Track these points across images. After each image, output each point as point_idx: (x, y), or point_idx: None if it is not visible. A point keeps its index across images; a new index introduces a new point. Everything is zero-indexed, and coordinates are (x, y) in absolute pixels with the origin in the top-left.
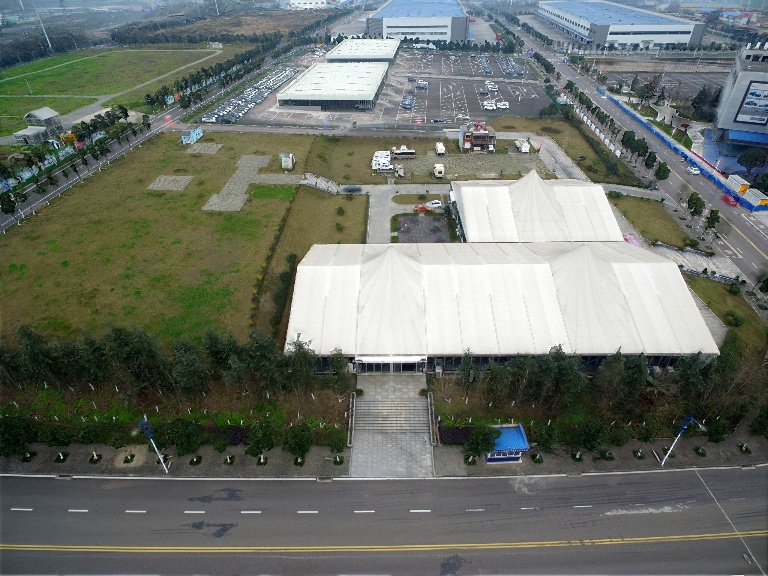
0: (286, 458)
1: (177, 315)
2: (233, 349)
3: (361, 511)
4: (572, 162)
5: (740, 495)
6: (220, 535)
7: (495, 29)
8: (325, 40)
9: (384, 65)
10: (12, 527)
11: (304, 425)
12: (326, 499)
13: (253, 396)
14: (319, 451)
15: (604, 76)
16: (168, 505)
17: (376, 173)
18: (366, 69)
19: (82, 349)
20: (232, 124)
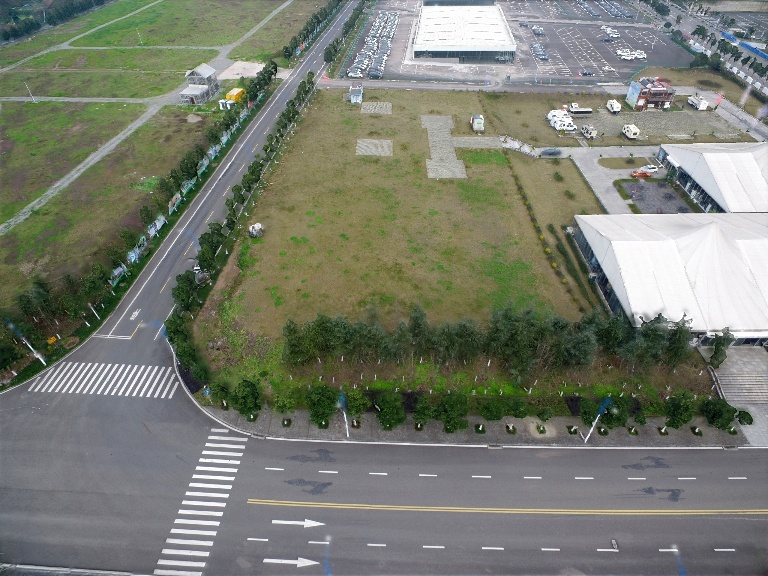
0: (682, 428)
1: (496, 290)
2: (619, 327)
3: None
4: (757, 121)
5: None
6: (675, 499)
7: None
8: None
9: (496, 9)
10: (486, 493)
11: None
12: (746, 466)
13: (617, 370)
14: None
15: (732, 20)
16: (608, 472)
17: (563, 134)
18: (482, 14)
19: (487, 329)
20: (382, 79)
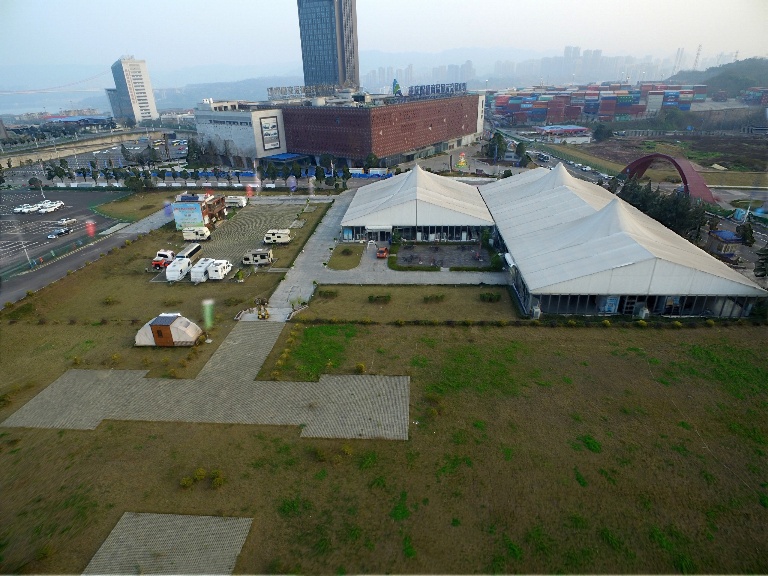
0: None
1: None
2: None
3: None
4: (286, 196)
5: None
6: None
7: None
8: None
9: None
10: None
11: None
12: None
13: None
14: None
15: (62, 160)
16: None
17: None
18: None
19: None
20: None
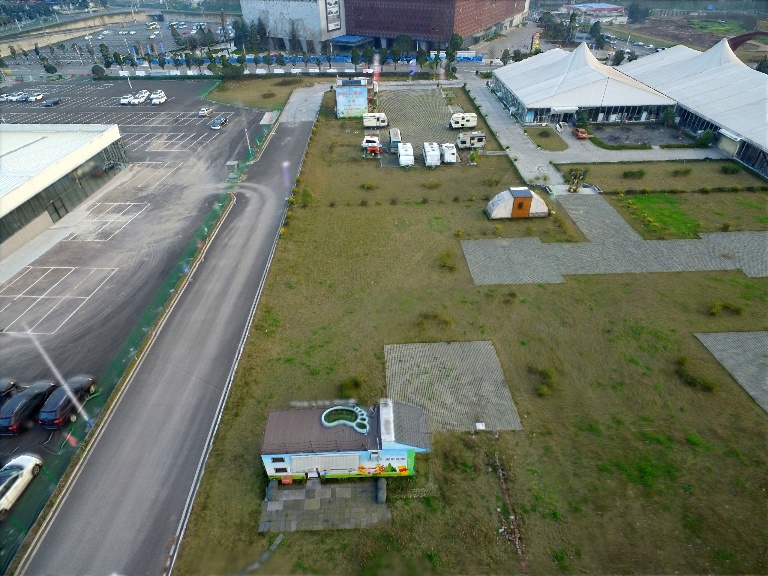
0: None
1: None
2: None
3: None
4: (404, 81)
5: None
6: None
7: None
8: None
9: None
10: None
11: None
12: None
13: None
14: None
15: (103, 45)
16: None
17: None
18: None
19: None
20: (121, 381)
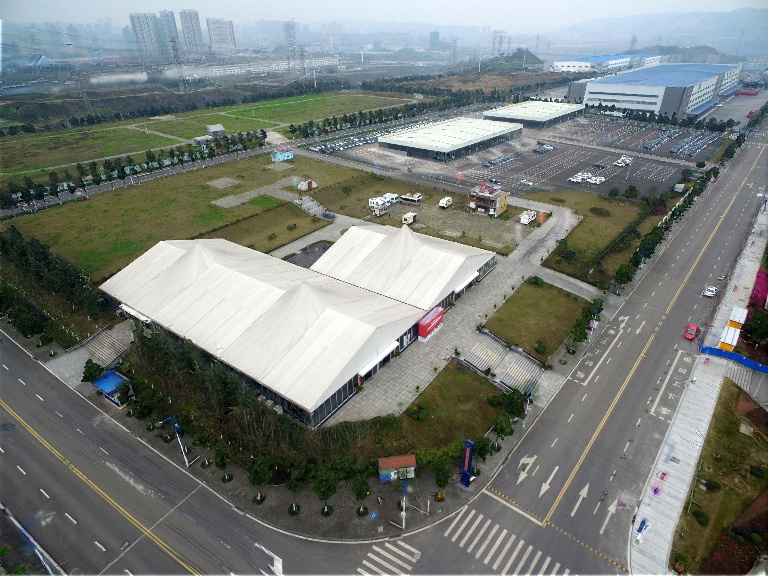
0: (39, 341)
1: None
2: None
3: (21, 381)
4: None
5: (196, 517)
6: None
7: (765, 105)
8: (514, 100)
9: None
10: None
11: (35, 318)
12: (20, 367)
13: (70, 305)
14: (54, 345)
15: None
16: None
17: (366, 209)
18: (491, 127)
19: None
20: (325, 154)
